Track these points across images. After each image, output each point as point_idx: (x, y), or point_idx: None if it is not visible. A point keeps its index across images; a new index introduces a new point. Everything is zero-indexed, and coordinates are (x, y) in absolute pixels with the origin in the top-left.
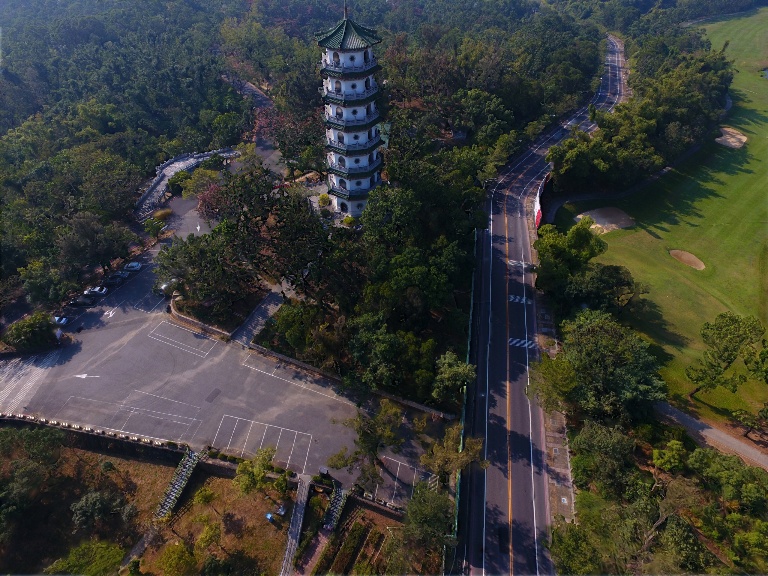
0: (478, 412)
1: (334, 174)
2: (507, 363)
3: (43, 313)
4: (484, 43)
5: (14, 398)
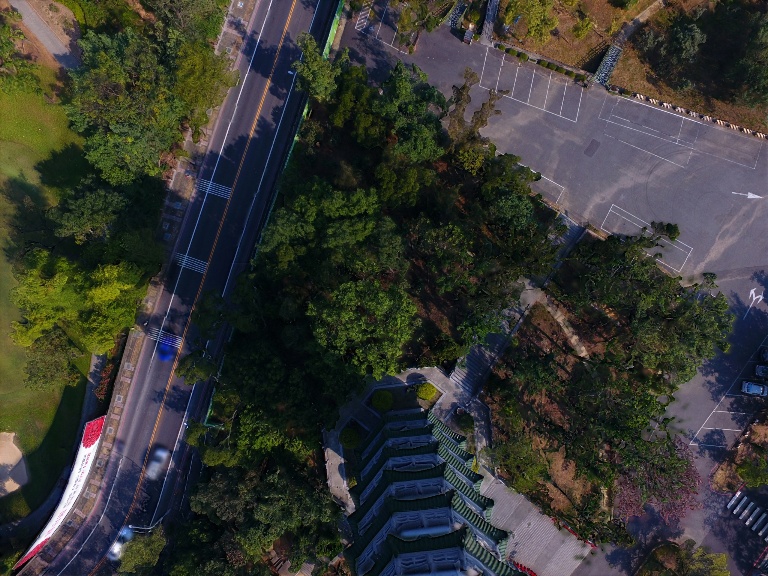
0: (296, 104)
1: None
2: (243, 161)
3: None
4: None
5: None
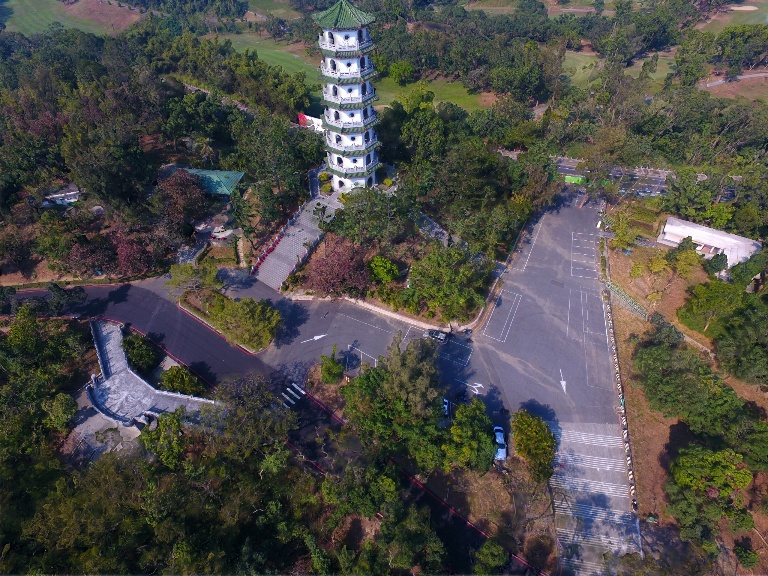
0: None
1: (359, 158)
2: None
3: (520, 416)
4: (5, 92)
5: (603, 446)
